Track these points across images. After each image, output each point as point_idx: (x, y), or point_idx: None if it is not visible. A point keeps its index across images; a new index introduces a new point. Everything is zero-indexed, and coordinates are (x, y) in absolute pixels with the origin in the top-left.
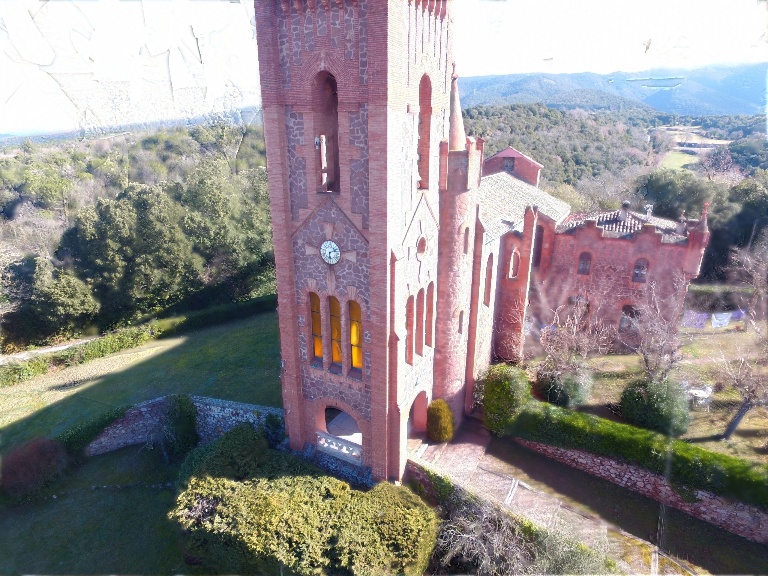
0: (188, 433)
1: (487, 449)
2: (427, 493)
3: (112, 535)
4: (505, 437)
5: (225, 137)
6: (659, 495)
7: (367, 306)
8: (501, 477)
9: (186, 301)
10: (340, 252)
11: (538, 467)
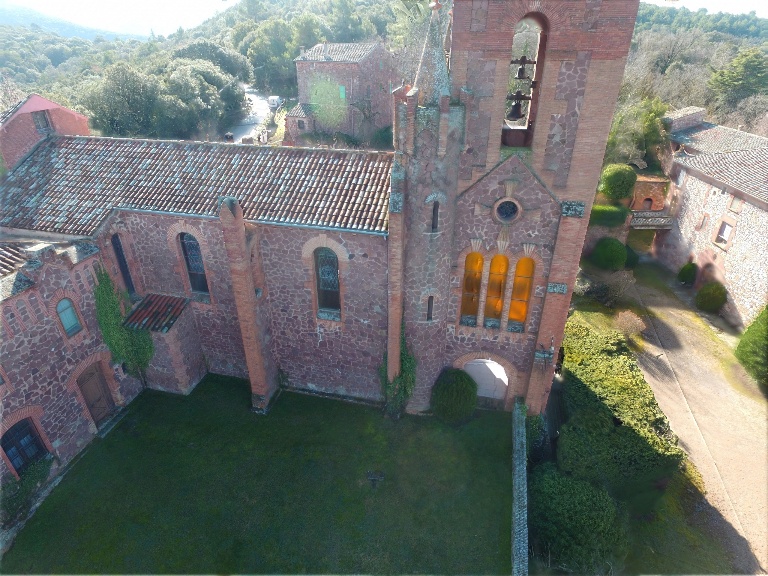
0: None
1: None
2: None
3: None
4: None
5: None
6: None
7: None
8: None
9: None
10: None
11: None
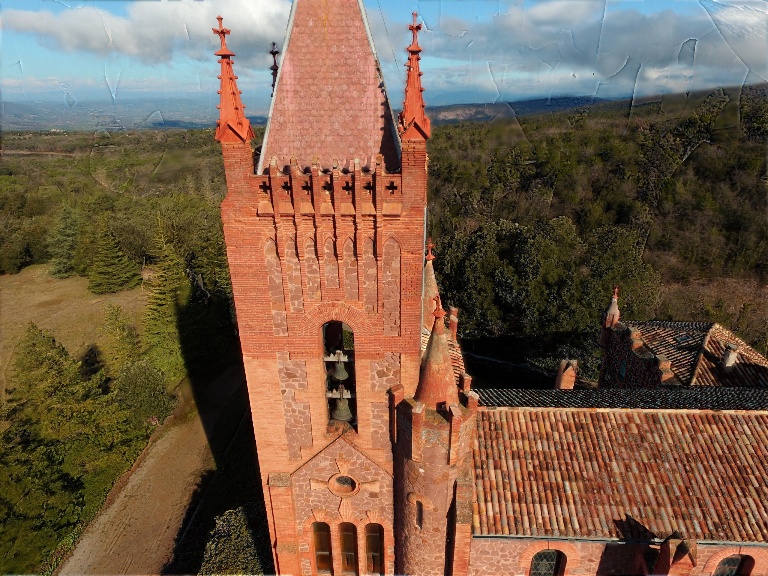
0: None
1: None
2: None
3: None
4: None
5: None
6: None
7: None
8: None
9: (484, 340)
10: None
11: None
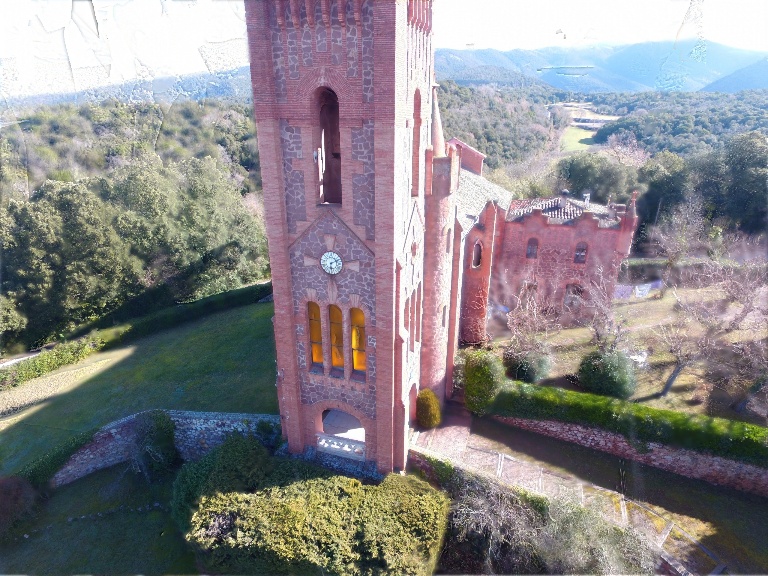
0: (167, 449)
1: (471, 429)
2: (428, 477)
3: (105, 566)
4: (484, 416)
5: (136, 121)
6: (618, 450)
7: (371, 312)
8: (488, 453)
9: (125, 307)
10: (342, 262)
11: (517, 439)
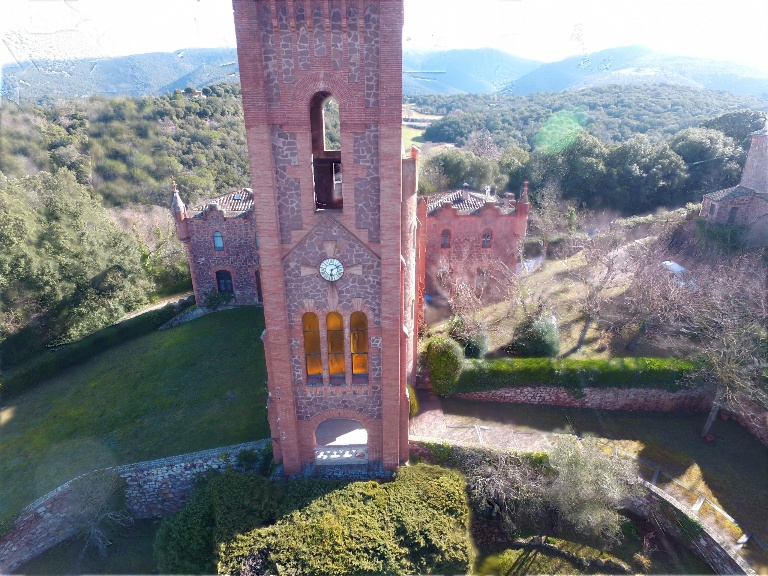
0: None
1: (443, 411)
2: (427, 463)
3: None
4: (449, 396)
5: None
6: (560, 401)
7: (374, 314)
8: (466, 428)
9: None
10: (343, 268)
11: (482, 411)
